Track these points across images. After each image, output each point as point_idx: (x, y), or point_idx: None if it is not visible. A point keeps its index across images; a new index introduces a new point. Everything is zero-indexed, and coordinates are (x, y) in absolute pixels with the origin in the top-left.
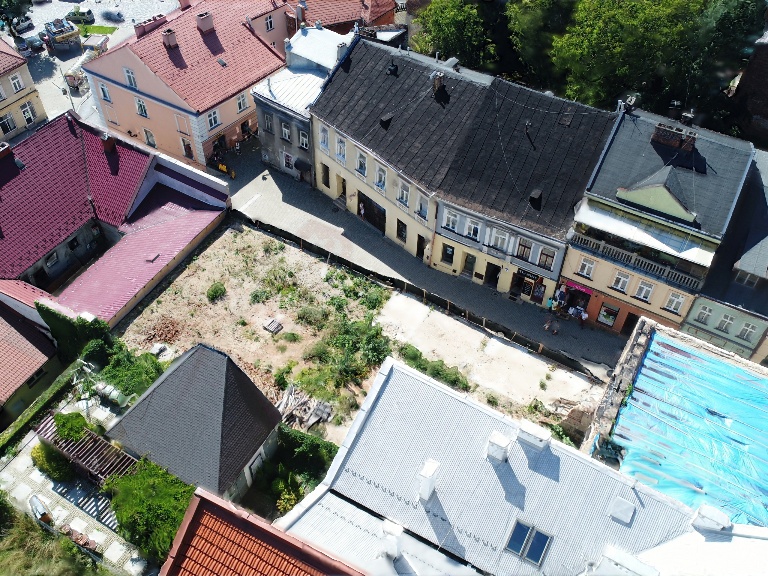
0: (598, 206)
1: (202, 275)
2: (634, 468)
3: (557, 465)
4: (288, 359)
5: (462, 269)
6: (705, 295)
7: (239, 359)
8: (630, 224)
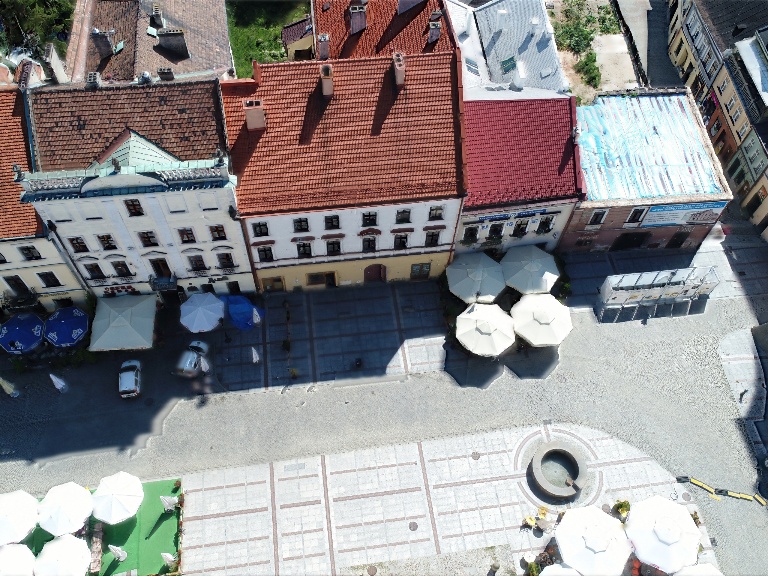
0: (756, 45)
1: None
2: (590, 109)
3: (545, 48)
4: None
5: (681, 64)
6: (755, 127)
7: None
8: (759, 63)
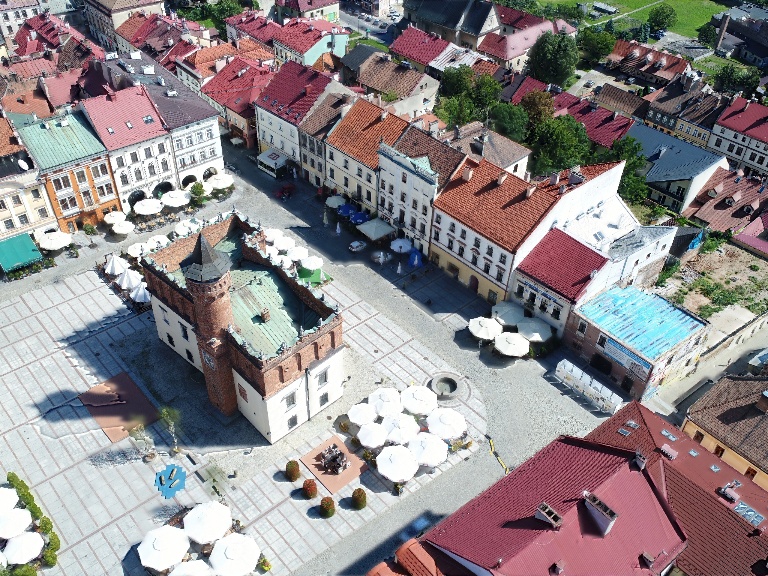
0: None
1: (767, 267)
2: None
3: None
4: (716, 279)
5: None
6: None
7: (716, 268)
8: None
